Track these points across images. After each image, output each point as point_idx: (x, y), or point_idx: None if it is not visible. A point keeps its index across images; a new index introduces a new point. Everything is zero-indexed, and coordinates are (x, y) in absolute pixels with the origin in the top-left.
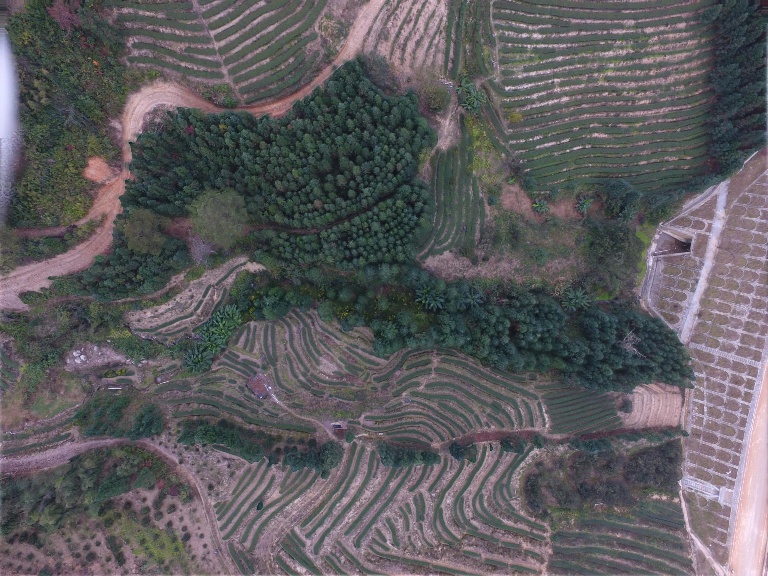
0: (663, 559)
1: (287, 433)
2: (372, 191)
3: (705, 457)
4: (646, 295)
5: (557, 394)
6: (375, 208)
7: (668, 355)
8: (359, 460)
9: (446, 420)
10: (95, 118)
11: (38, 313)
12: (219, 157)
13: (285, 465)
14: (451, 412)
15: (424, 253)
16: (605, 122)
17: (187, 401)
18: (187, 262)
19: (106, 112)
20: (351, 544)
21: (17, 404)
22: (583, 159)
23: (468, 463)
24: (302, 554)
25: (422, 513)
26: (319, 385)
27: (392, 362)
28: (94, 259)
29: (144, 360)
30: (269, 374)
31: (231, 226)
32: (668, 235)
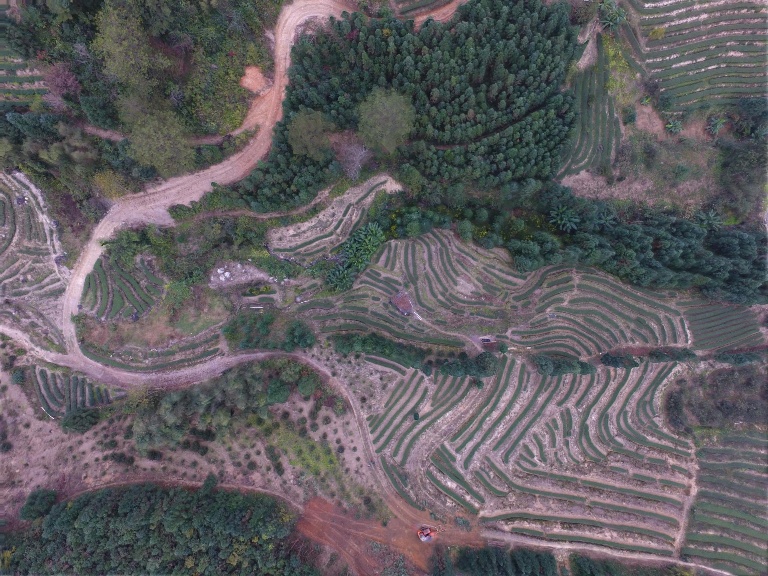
0: None
1: (436, 347)
2: (525, 101)
3: None
4: None
5: (700, 310)
6: (529, 117)
7: None
8: (510, 373)
9: (592, 335)
10: (254, 26)
11: (184, 229)
12: (377, 65)
13: (444, 373)
14: (596, 327)
15: (560, 173)
16: (743, 40)
17: (333, 317)
18: (338, 174)
19: (263, 21)
20: (499, 459)
21: (162, 321)
22: (717, 79)
23: (614, 378)
24: (453, 468)
25: (569, 429)
26: (458, 305)
27: (530, 282)
28: (246, 171)
29: (286, 278)
30: (410, 292)
31: (404, 124)
32: None
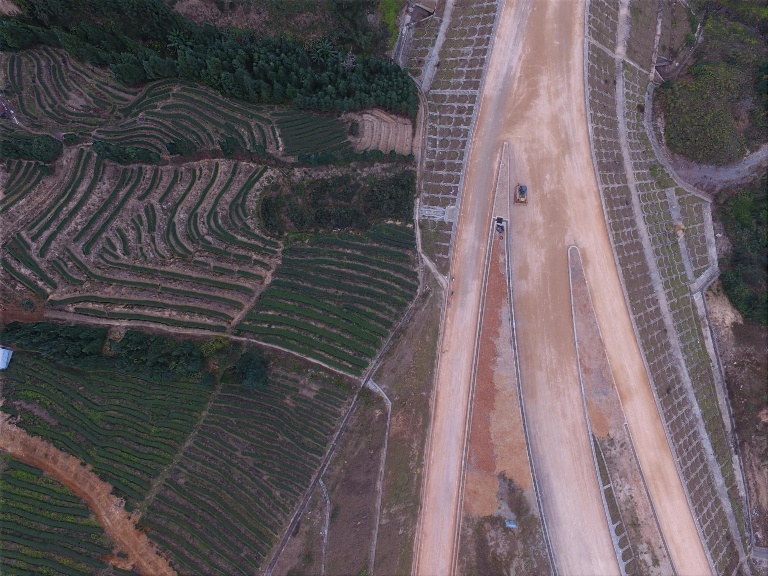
0: (388, 270)
1: None
2: None
3: (436, 184)
4: (398, 58)
5: (289, 118)
6: None
7: (393, 83)
8: (85, 164)
9: (178, 136)
10: None
11: None
12: None
13: None
14: (184, 130)
15: None
16: None
17: None
18: None
19: None
20: (80, 251)
21: None
22: None
23: (199, 177)
24: (27, 255)
25: (153, 224)
26: (66, 116)
27: (139, 97)
28: None
29: None
30: (13, 101)
31: None
32: (421, 8)
